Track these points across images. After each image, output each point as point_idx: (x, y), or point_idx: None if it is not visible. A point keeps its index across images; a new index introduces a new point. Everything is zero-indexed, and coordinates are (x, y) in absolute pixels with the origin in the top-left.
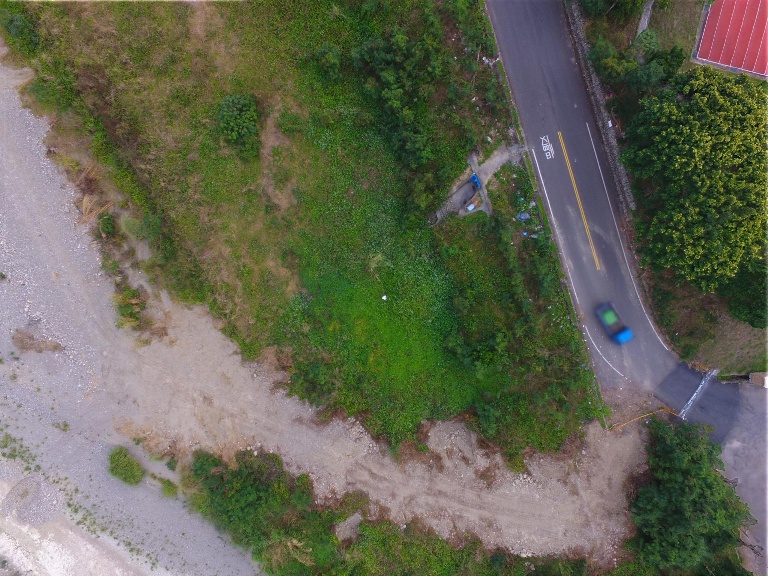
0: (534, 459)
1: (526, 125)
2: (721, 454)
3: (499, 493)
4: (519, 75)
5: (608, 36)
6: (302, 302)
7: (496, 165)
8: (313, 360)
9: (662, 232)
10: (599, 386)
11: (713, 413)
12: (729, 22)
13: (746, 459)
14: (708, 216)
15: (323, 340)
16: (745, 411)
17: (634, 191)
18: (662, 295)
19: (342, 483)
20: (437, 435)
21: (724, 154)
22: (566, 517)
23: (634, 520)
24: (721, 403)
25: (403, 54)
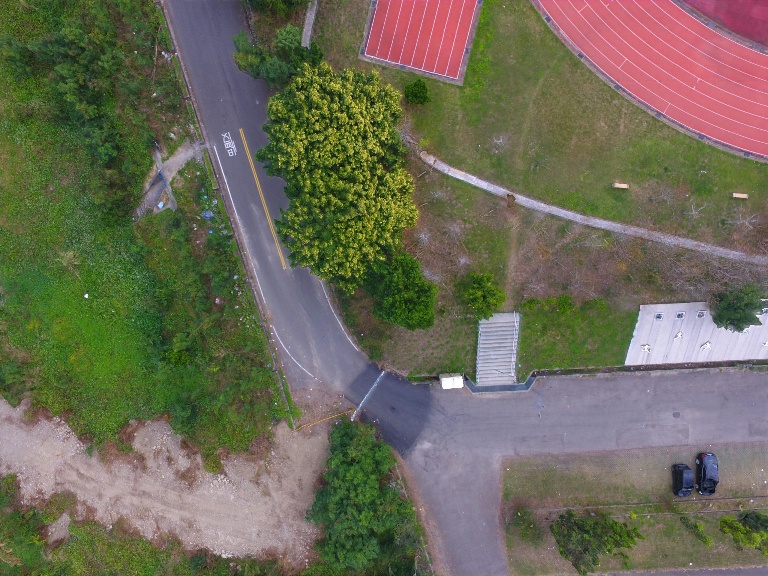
0: (230, 460)
1: (207, 122)
2: (412, 455)
3: (199, 494)
4: (198, 70)
5: (274, 31)
6: (1, 300)
7: (181, 162)
8: (13, 359)
9: (284, 232)
10: (289, 387)
11: (404, 414)
12: (396, 19)
13: (437, 460)
14: (313, 216)
15: (22, 339)
16: (436, 412)
17: (284, 190)
18: (343, 295)
19: (51, 483)
20: (149, 435)
21: (321, 153)
22: (259, 518)
23: (315, 521)
24: (412, 404)
25: (79, 47)
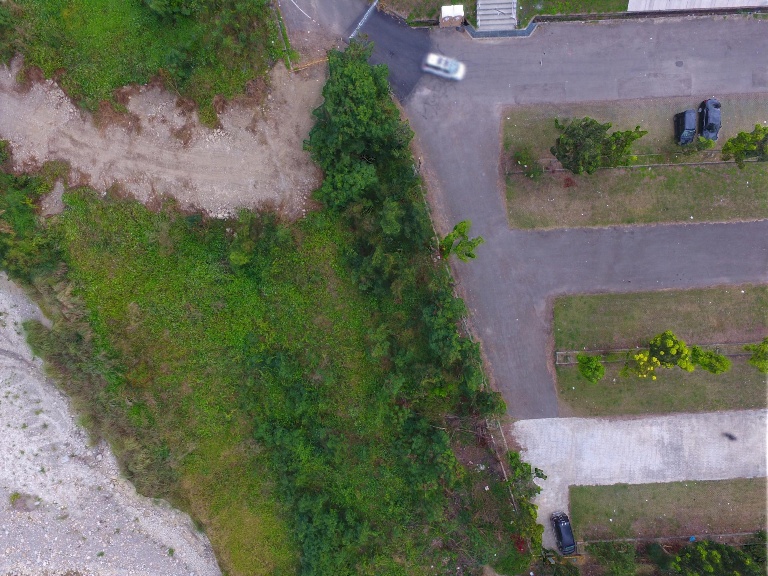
0: (226, 111)
1: None
2: (411, 102)
3: (194, 151)
4: None
5: None
6: None
7: None
8: None
9: None
10: (286, 28)
11: (403, 59)
12: None
13: (436, 107)
14: None
15: None
16: (436, 58)
17: None
18: None
19: (44, 152)
20: (143, 105)
21: None
22: (255, 168)
23: (313, 158)
24: (411, 49)
25: None
